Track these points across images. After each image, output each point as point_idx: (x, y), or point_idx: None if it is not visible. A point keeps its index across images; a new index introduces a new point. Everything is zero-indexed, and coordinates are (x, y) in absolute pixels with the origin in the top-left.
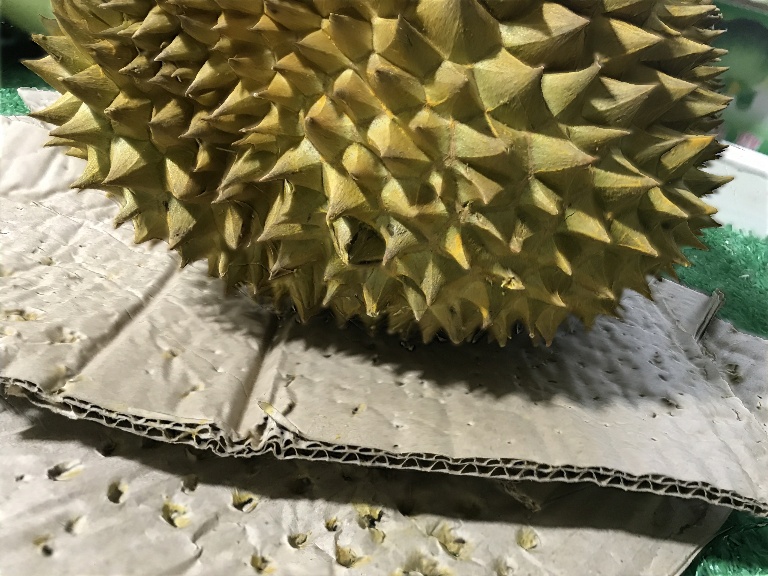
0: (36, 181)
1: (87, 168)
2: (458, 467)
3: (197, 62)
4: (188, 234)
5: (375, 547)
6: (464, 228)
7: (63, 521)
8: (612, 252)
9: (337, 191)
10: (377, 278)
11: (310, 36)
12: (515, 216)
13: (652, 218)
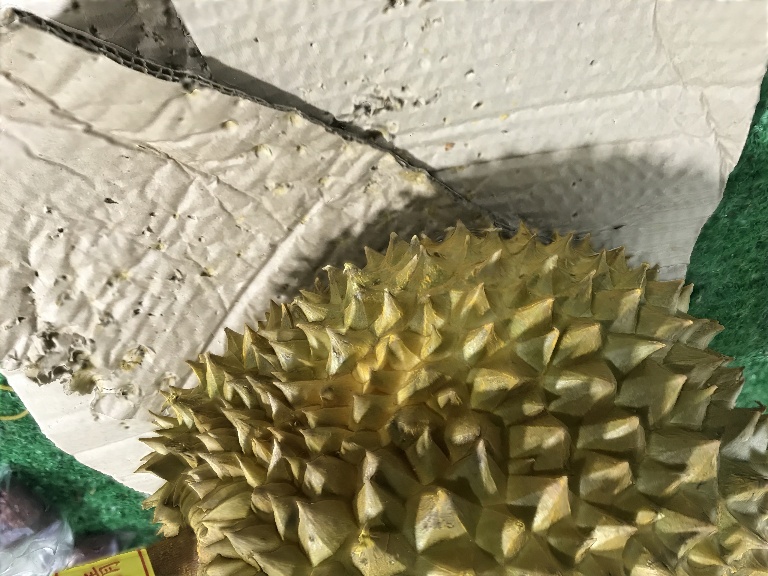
0: (142, 128)
1: None
2: None
3: None
4: None
5: None
6: None
7: None
8: None
9: None
10: None
11: None
12: None
13: None
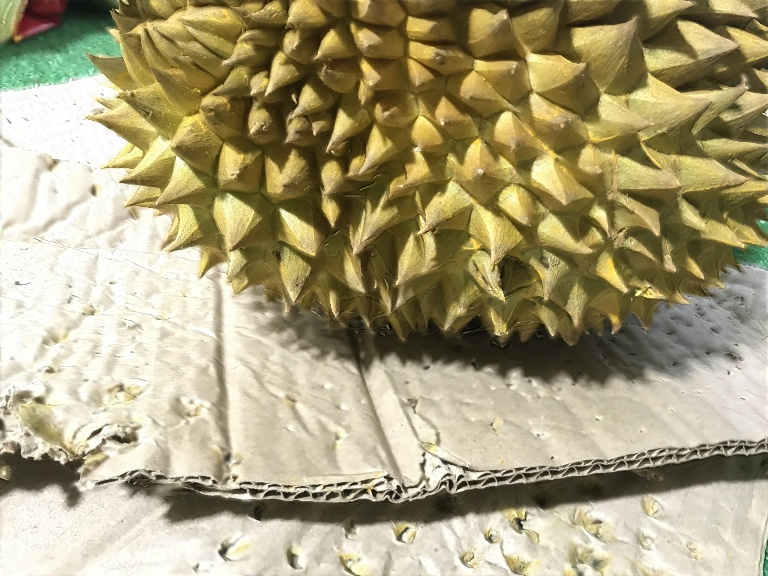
0: (29, 213)
1: (184, 227)
2: (610, 466)
3: (328, 111)
4: (305, 282)
5: (537, 549)
6: (616, 252)
7: None
8: (721, 246)
9: (497, 234)
10: (510, 301)
11: (470, 82)
12: (661, 234)
13: (752, 209)
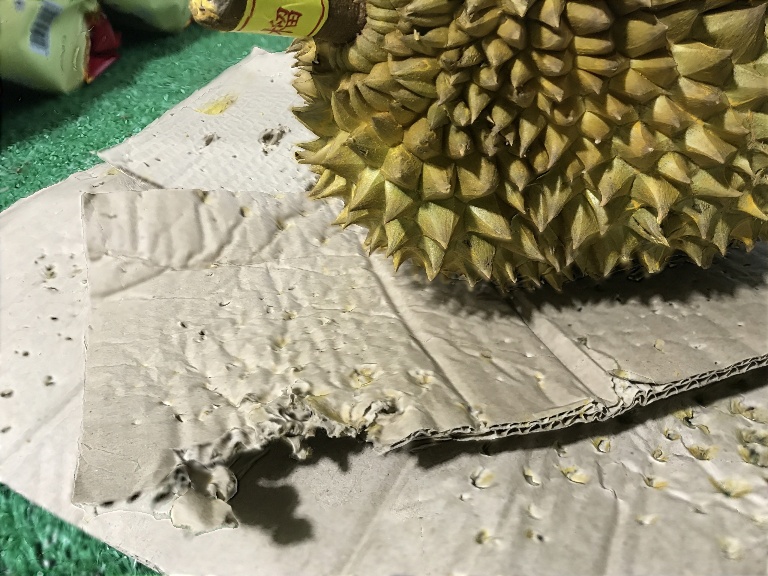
0: (201, 243)
1: (393, 235)
2: (763, 361)
3: (512, 123)
4: None
5: (710, 438)
6: (754, 189)
7: (525, 514)
8: None
9: (660, 194)
10: None
11: (633, 80)
12: None
13: None
